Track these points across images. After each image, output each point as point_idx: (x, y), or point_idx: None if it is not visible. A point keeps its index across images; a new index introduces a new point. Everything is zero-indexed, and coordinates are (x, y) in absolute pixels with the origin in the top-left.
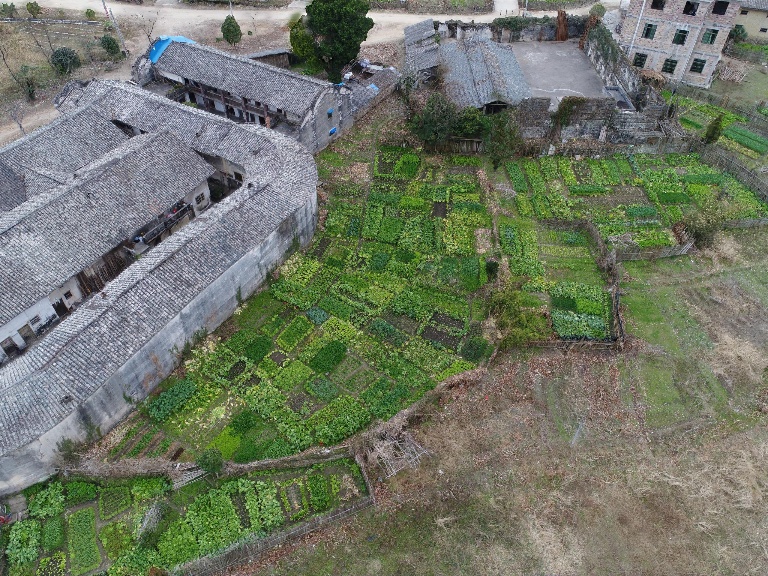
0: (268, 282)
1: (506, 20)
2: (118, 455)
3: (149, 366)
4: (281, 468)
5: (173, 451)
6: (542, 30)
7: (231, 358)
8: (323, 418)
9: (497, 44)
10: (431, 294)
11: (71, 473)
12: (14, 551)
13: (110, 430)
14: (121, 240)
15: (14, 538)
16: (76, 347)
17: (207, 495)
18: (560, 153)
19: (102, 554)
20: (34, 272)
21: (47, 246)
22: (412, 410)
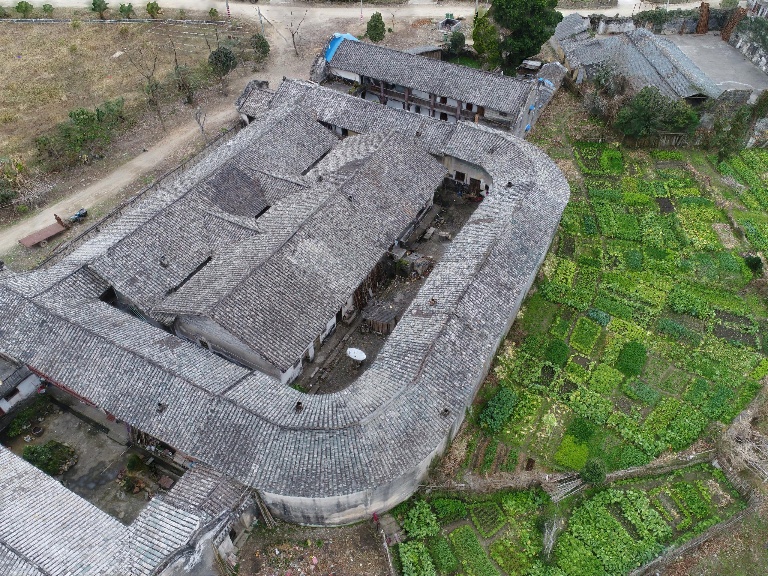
0: (536, 284)
1: (651, 13)
2: (469, 469)
3: (481, 374)
4: (642, 476)
5: (523, 462)
6: (685, 23)
7: (535, 363)
8: (658, 422)
9: (659, 37)
10: (701, 291)
11: (434, 490)
12: (413, 575)
13: (451, 443)
14: (390, 244)
15: (407, 561)
16: (436, 357)
17: (585, 507)
18: (759, 145)
19: (502, 574)
20: (327, 280)
21: (330, 252)
22: (754, 411)
